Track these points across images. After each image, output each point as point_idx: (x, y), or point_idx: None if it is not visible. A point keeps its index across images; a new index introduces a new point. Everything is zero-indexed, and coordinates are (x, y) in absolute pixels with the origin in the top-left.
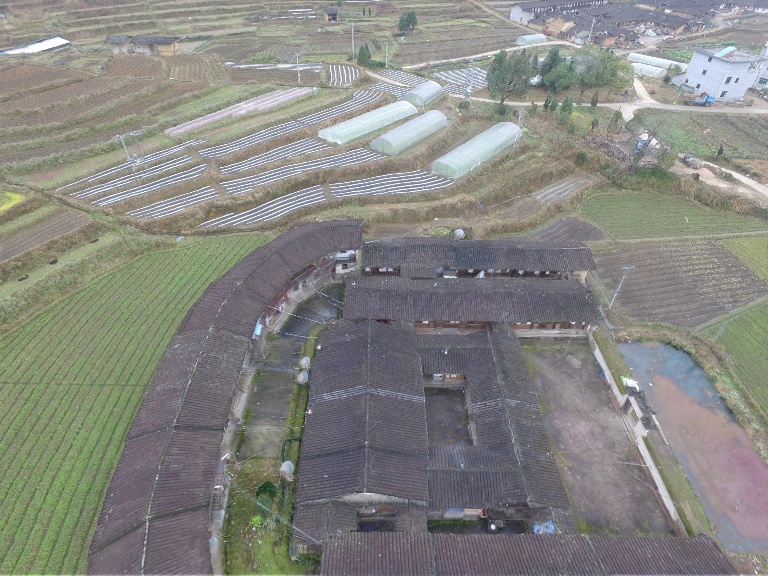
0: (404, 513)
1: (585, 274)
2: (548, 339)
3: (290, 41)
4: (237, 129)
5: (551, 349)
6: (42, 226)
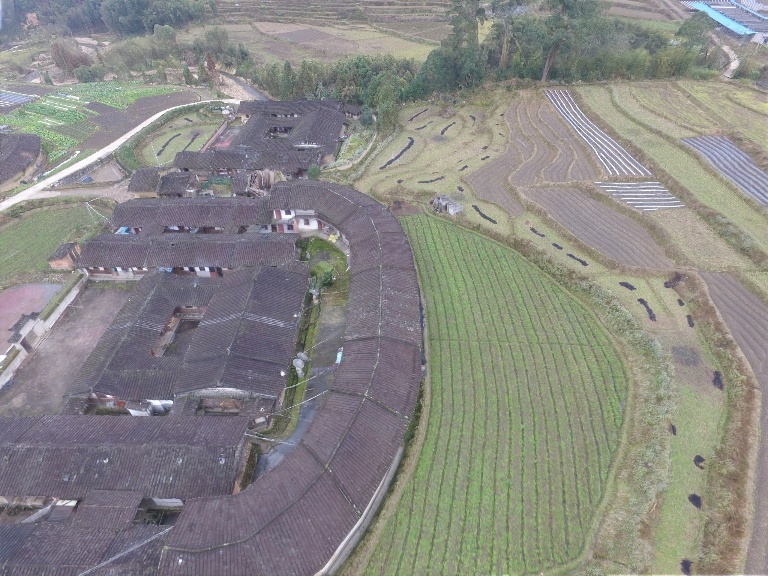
0: None
1: None
2: None
3: None
4: None
5: None
6: None
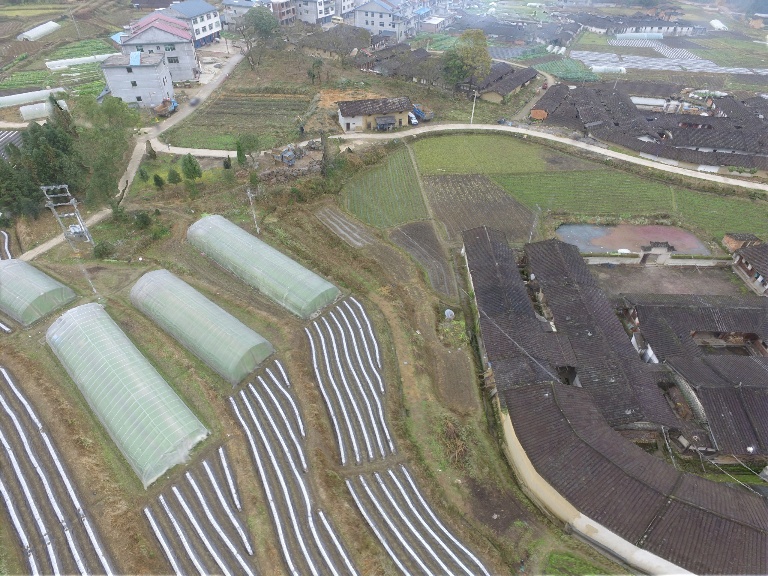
0: None
1: None
2: None
3: None
4: None
5: None
6: None
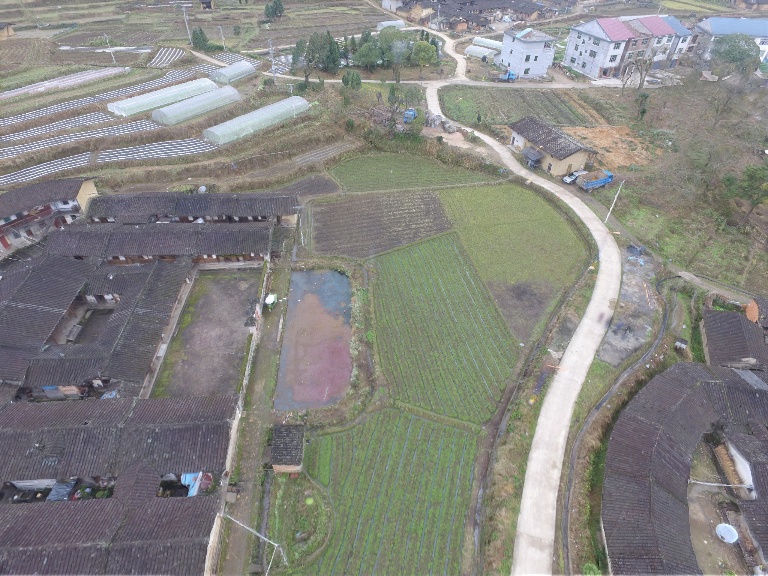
0: None
1: (293, 219)
2: (232, 270)
3: (154, 28)
4: (28, 104)
5: (230, 277)
6: None
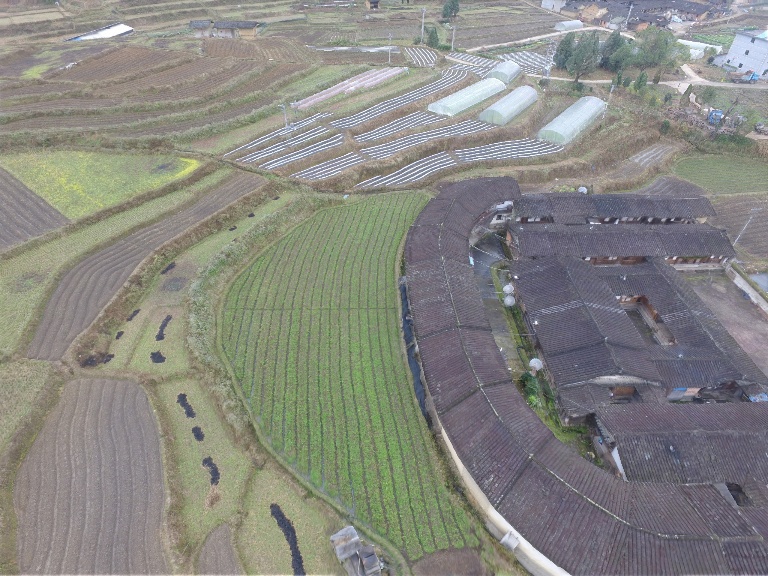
0: (646, 391)
1: (704, 221)
2: (691, 272)
3: (343, 27)
4: (354, 103)
5: (696, 279)
6: (227, 186)
